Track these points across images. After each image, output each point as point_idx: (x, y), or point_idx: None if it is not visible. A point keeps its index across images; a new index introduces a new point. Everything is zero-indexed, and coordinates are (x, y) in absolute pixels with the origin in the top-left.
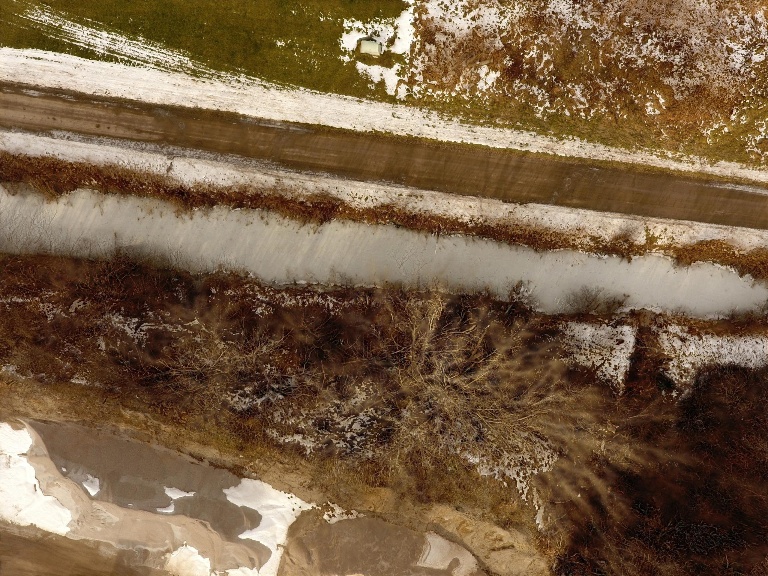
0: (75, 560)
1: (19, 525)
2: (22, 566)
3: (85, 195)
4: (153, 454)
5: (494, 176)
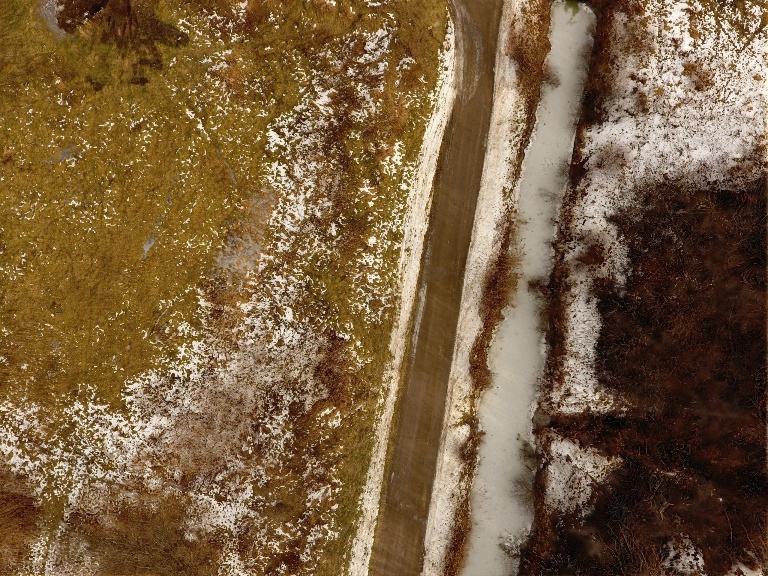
0: None
1: None
2: None
3: None
4: None
5: None
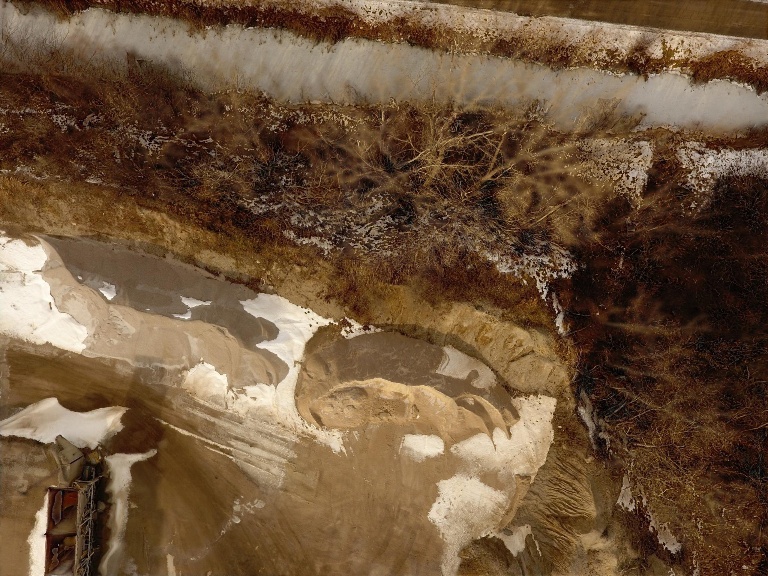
0: (91, 378)
1: (35, 344)
2: (38, 385)
3: (97, 14)
4: (169, 268)
5: None
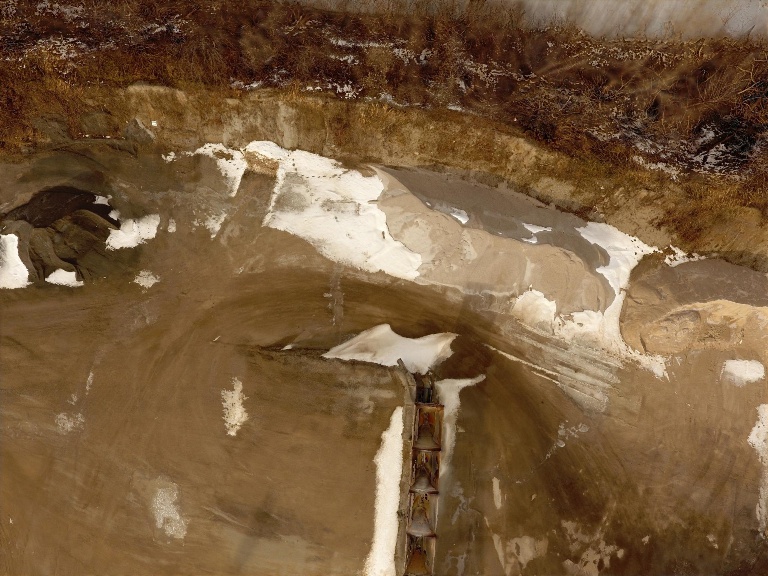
0: (423, 305)
1: (368, 272)
2: (371, 312)
3: None
4: (502, 198)
5: None
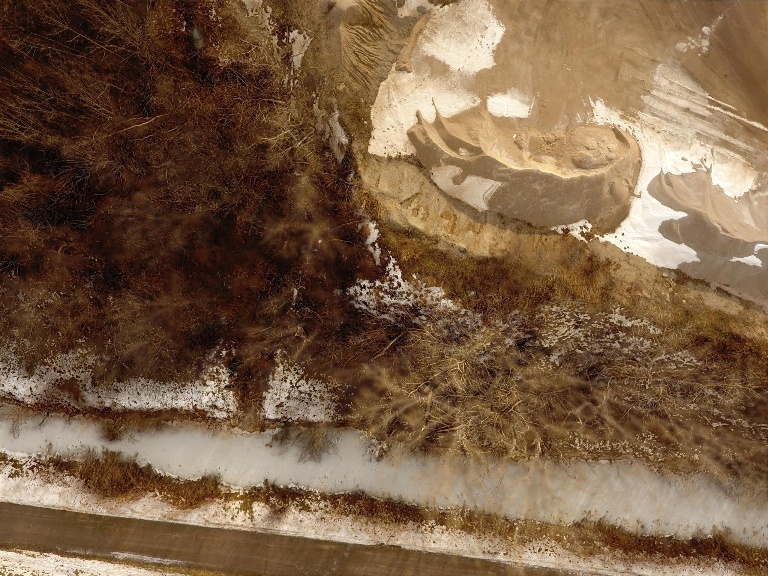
0: None
1: None
2: None
3: None
4: (767, 296)
5: (410, 573)
